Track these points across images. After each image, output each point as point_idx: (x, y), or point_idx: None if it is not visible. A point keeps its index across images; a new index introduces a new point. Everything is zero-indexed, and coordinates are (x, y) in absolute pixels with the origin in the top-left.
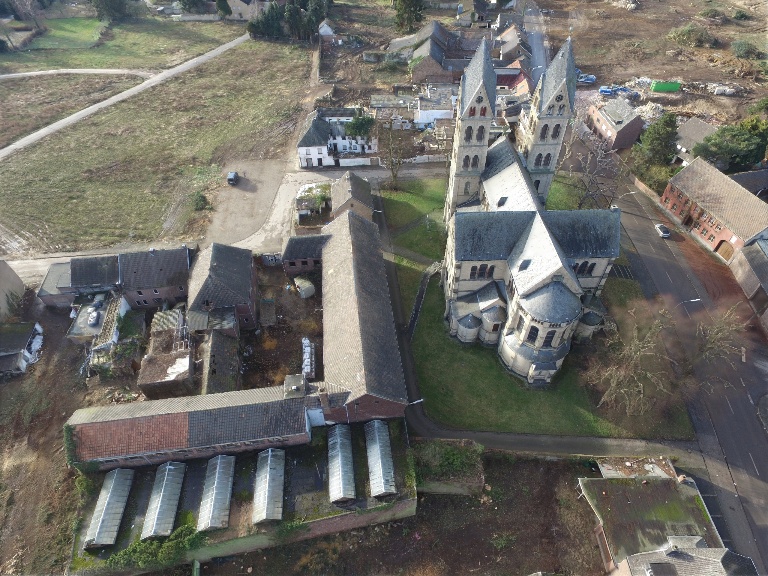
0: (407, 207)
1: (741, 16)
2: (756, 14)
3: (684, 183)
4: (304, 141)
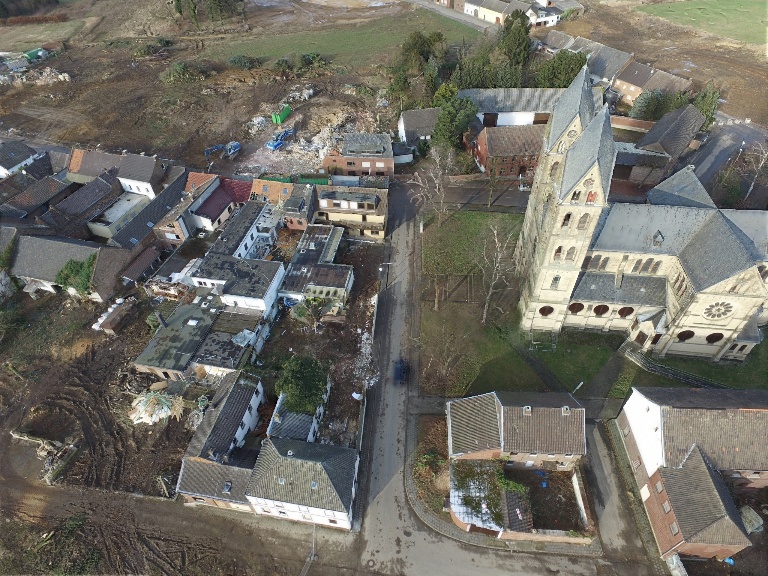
0: (496, 367)
1: (166, 43)
2: (166, 38)
3: (500, 150)
4: (342, 492)
